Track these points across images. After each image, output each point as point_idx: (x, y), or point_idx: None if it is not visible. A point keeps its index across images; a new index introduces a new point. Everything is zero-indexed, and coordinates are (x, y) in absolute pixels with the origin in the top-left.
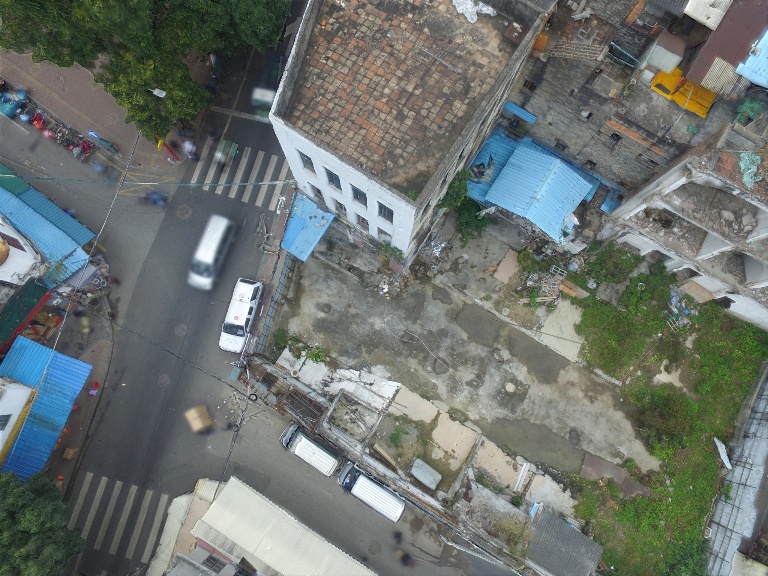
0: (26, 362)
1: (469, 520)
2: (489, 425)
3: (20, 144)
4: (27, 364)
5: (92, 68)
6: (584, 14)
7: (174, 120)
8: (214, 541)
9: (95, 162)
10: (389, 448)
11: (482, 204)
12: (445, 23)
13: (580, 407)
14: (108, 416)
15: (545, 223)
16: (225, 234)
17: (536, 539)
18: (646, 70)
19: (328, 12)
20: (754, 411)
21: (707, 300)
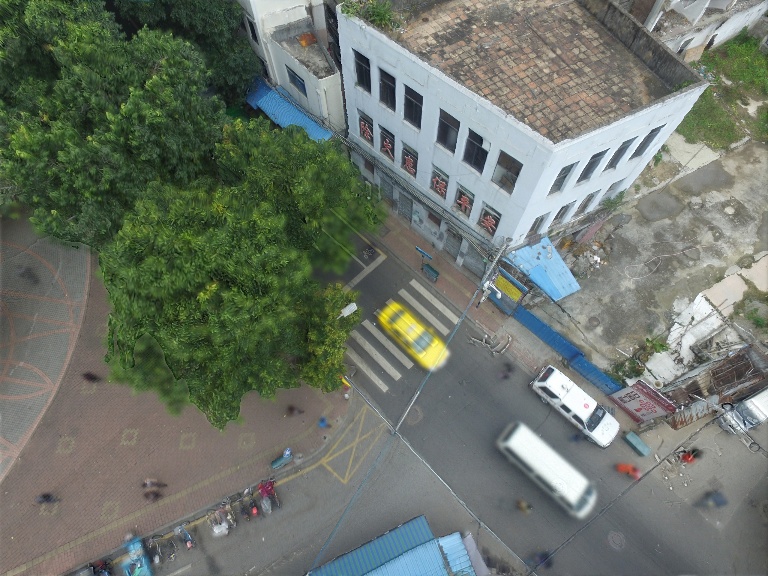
0: None
1: None
2: (762, 242)
3: None
4: None
5: None
6: None
7: None
8: None
9: None
10: (767, 333)
11: None
12: (496, 10)
13: (762, 172)
14: None
15: None
16: (463, 382)
17: None
18: None
19: None
20: None
21: (702, 52)
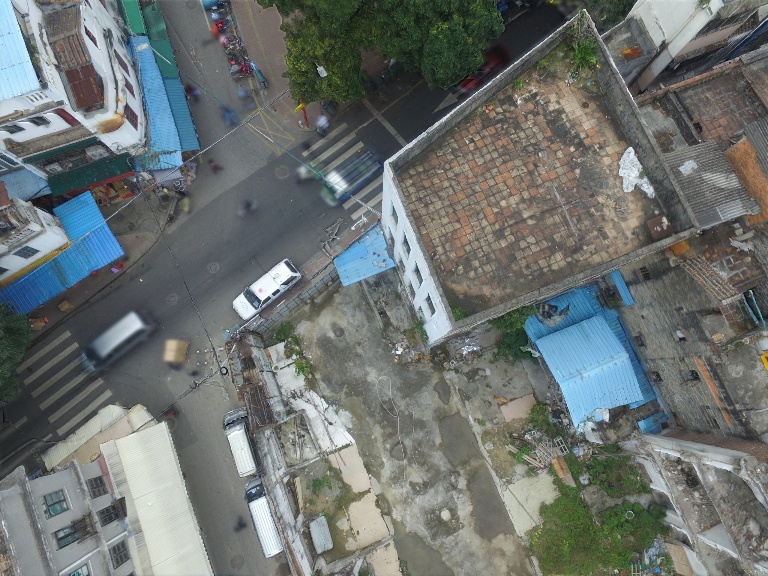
0: (79, 216)
1: None
2: (404, 533)
3: (198, 35)
4: (79, 218)
5: (285, 16)
6: (743, 245)
7: None
8: (112, 466)
9: (243, 86)
10: (307, 489)
11: (531, 342)
12: (599, 176)
13: None
14: (113, 297)
15: (574, 402)
16: (302, 213)
17: None
18: (767, 338)
19: (501, 100)
20: None
21: (685, 575)
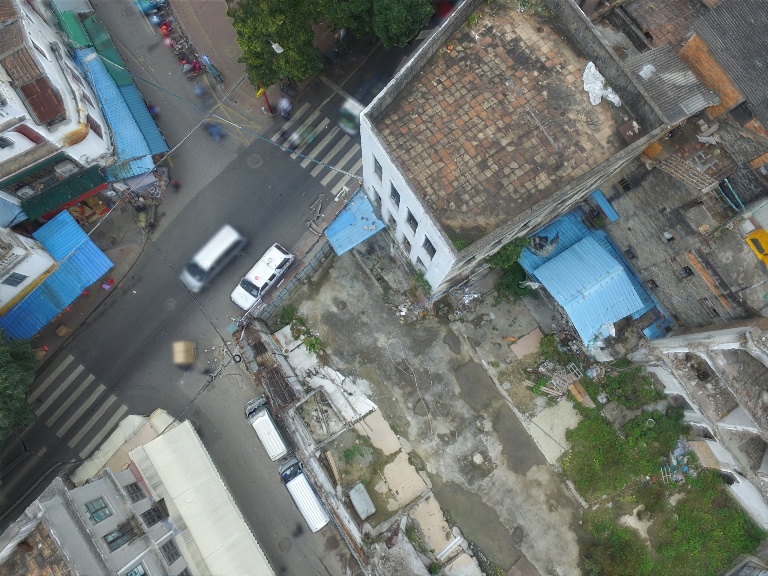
0: (61, 236)
1: (381, 565)
2: (442, 484)
3: (143, 41)
4: (61, 238)
5: (230, 1)
6: (710, 139)
7: (281, 76)
8: (145, 471)
9: (199, 83)
10: (339, 461)
11: (529, 275)
12: (566, 94)
13: (537, 509)
14: (109, 313)
15: (581, 321)
16: (282, 197)
17: None
18: (748, 220)
19: (460, 39)
20: None
21: (711, 467)
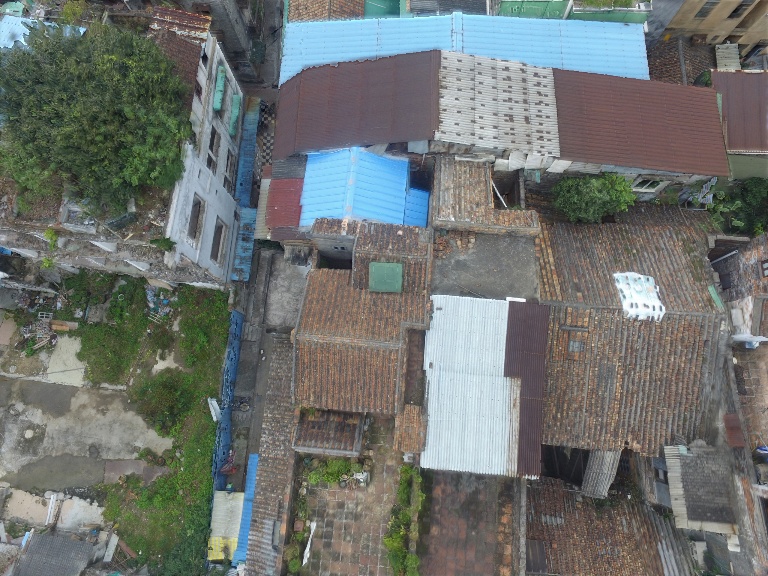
0: None
1: None
2: (16, 476)
3: None
4: None
5: None
6: None
7: None
8: None
9: None
10: None
11: None
12: None
13: (94, 423)
14: None
15: None
16: None
17: (26, 565)
18: None
19: None
20: None
21: (169, 286)
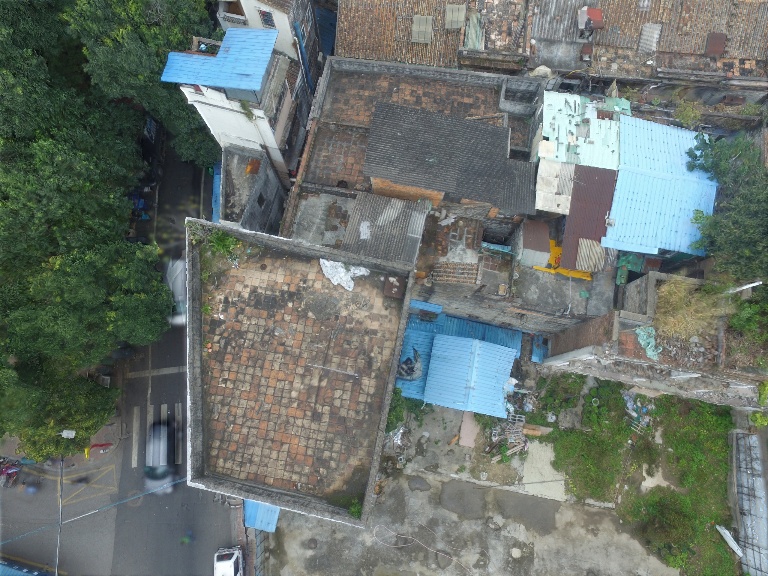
0: None
1: None
2: None
3: None
4: None
5: None
6: (448, 220)
7: None
8: None
9: (25, 481)
10: None
11: None
12: (325, 300)
13: (587, 545)
14: None
15: (488, 407)
16: (185, 506)
17: None
18: None
19: (210, 330)
20: (739, 485)
21: (657, 395)
